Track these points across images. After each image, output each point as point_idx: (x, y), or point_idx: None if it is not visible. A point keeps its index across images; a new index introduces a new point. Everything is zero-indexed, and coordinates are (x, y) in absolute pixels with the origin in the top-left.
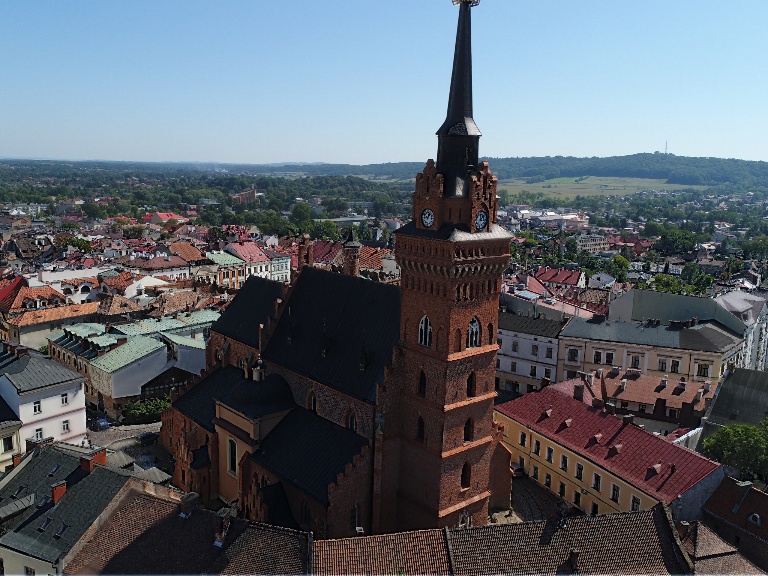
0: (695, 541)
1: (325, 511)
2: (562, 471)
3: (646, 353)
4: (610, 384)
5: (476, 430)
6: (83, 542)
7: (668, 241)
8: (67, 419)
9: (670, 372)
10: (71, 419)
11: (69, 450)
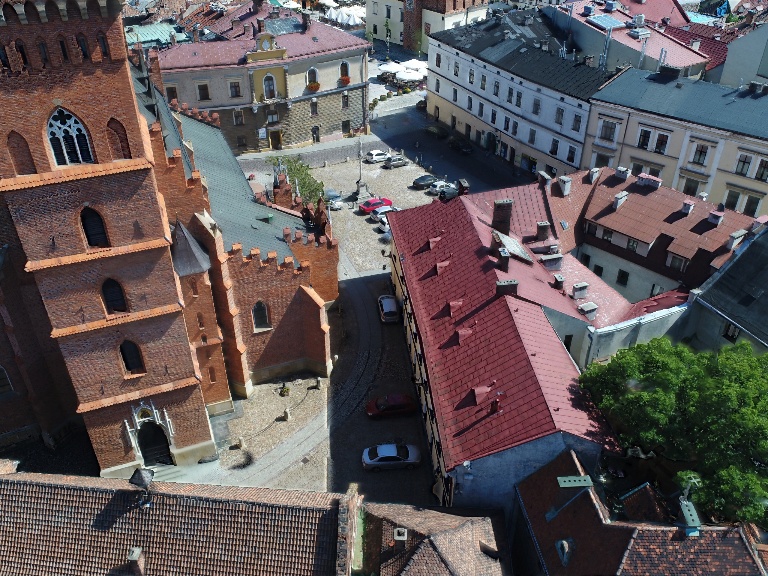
0: (399, 572)
1: None
2: None
3: (720, 142)
4: (601, 196)
5: (134, 296)
6: None
7: None
8: None
9: (753, 178)
10: None
11: None
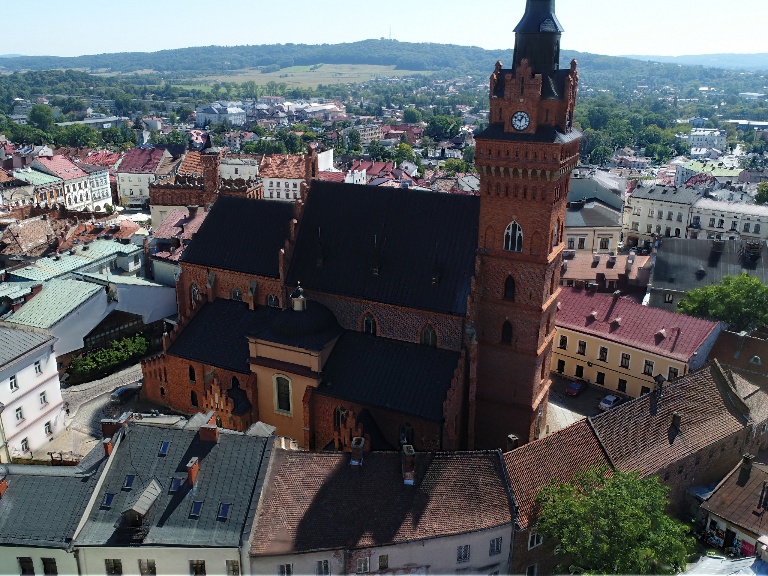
0: (735, 387)
1: (438, 428)
2: (562, 350)
3: None
4: None
5: (550, 325)
6: (256, 517)
7: (436, 127)
8: (43, 390)
9: (578, 249)
10: (47, 389)
11: (144, 423)
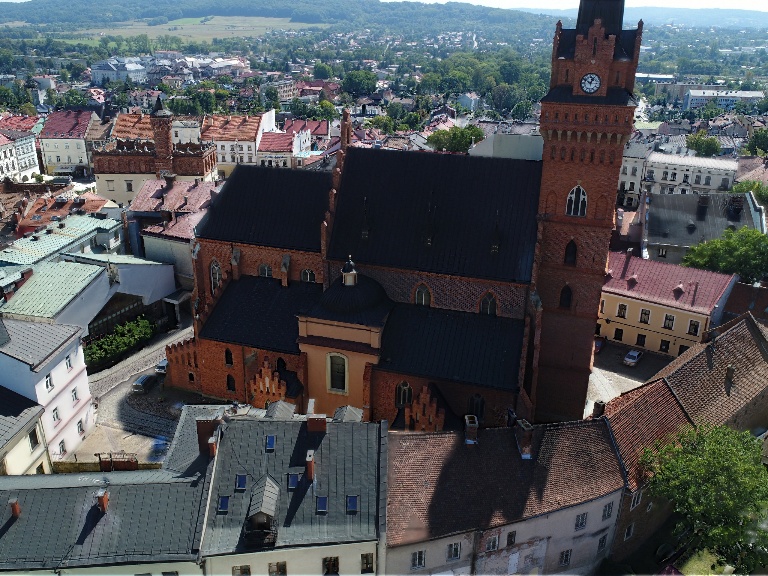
0: None
1: (512, 397)
2: None
3: None
4: None
5: None
6: None
7: (352, 83)
8: (74, 387)
9: None
10: (77, 385)
11: (231, 417)
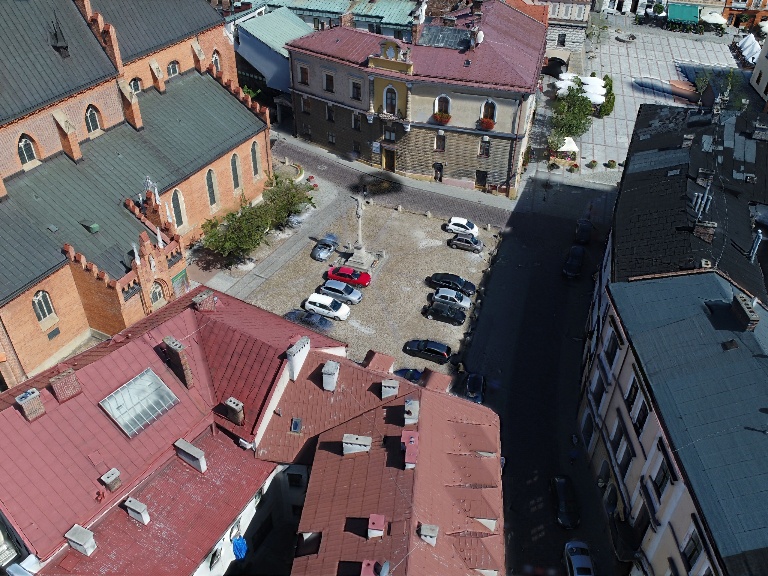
0: None
1: None
2: None
3: (678, 481)
4: (363, 422)
5: None
6: None
7: None
8: None
9: None
10: None
11: None
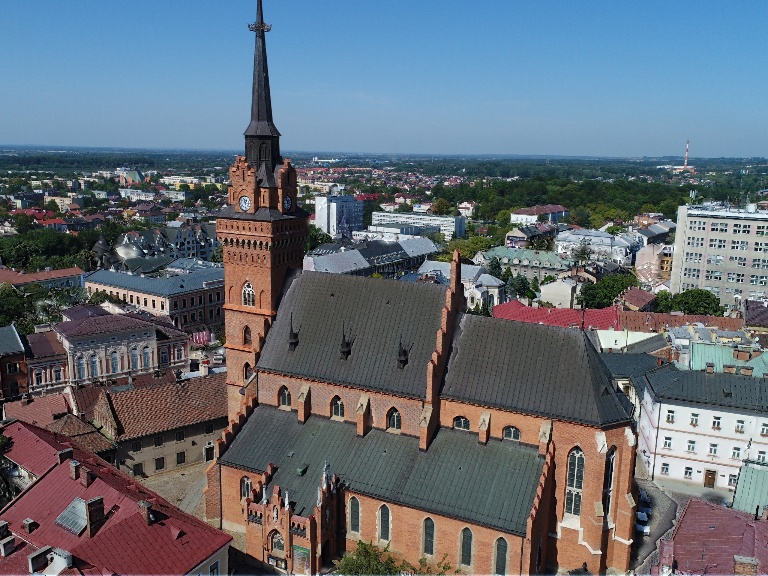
0: None
1: None
2: None
3: None
4: None
5: None
6: None
7: None
8: None
9: None
10: None
11: None
